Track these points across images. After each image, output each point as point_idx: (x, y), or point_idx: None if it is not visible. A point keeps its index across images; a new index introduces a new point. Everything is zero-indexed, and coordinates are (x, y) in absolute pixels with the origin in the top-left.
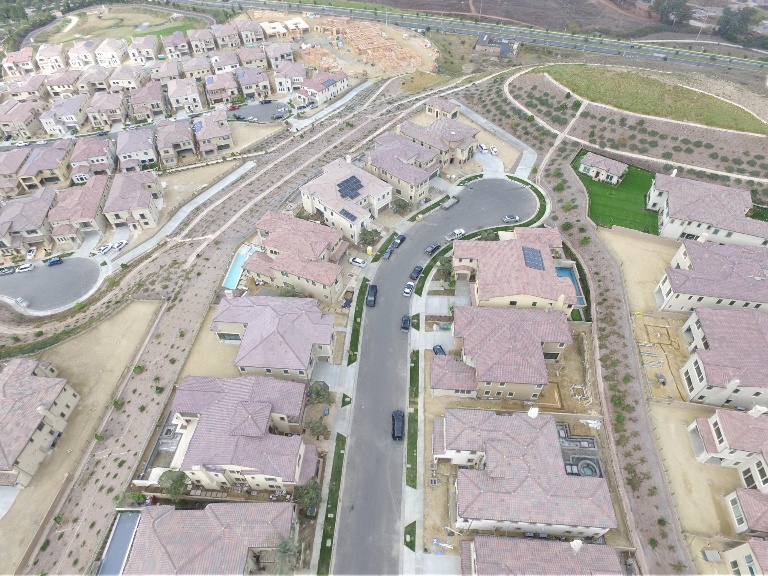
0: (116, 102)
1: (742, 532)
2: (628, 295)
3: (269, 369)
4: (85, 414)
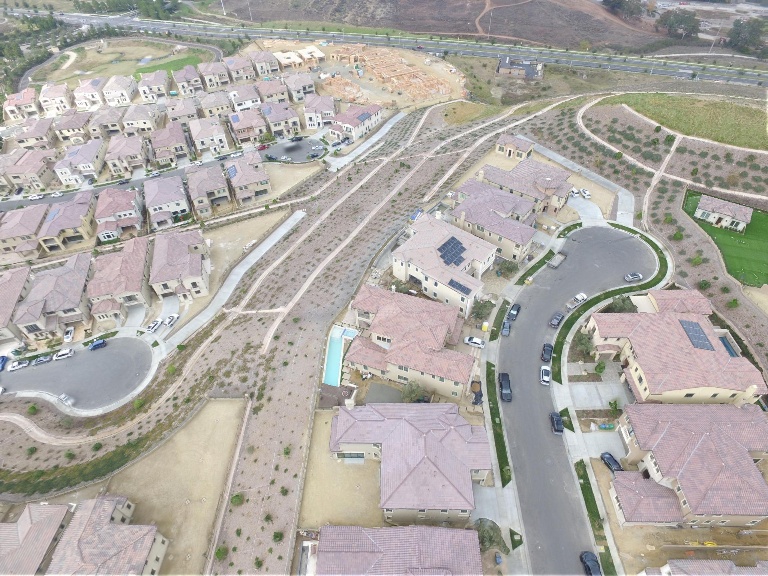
0: (136, 147)
1: None
2: None
3: (424, 509)
4: (178, 566)
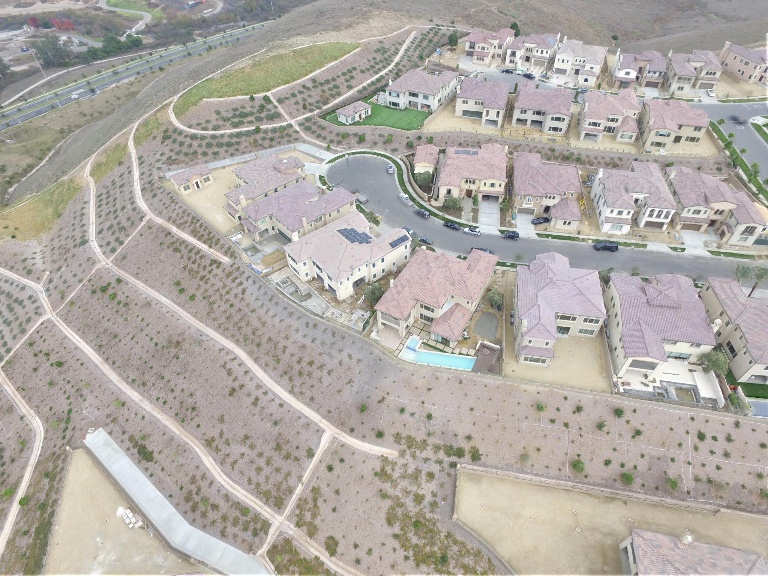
0: None
1: (635, 139)
2: None
3: None
4: None
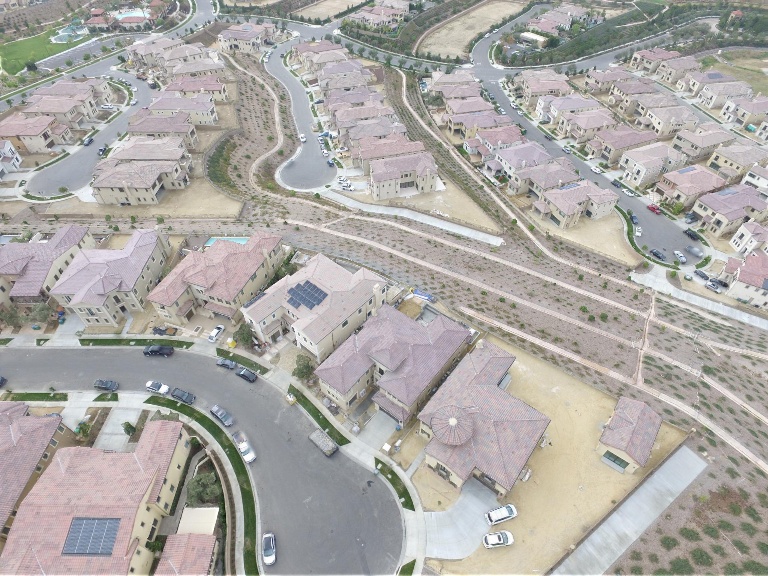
0: (593, 124)
1: None
2: None
3: None
4: (142, 210)
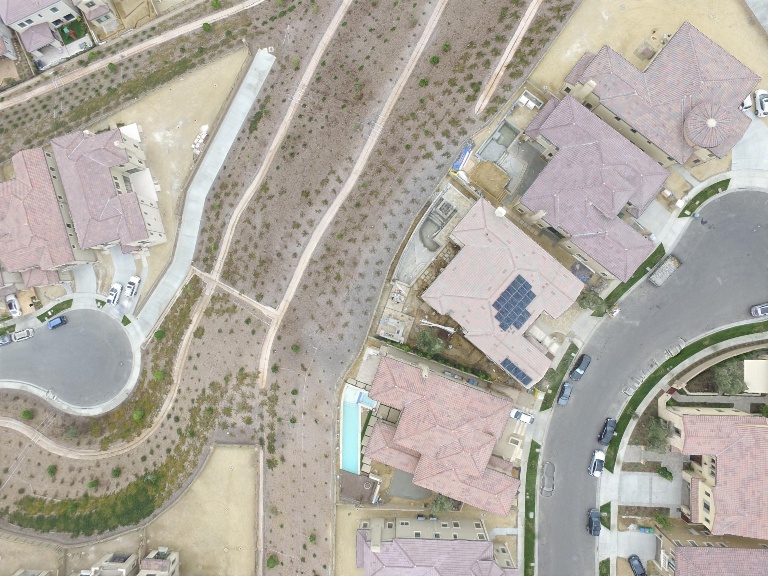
0: None
1: None
2: None
3: None
4: None
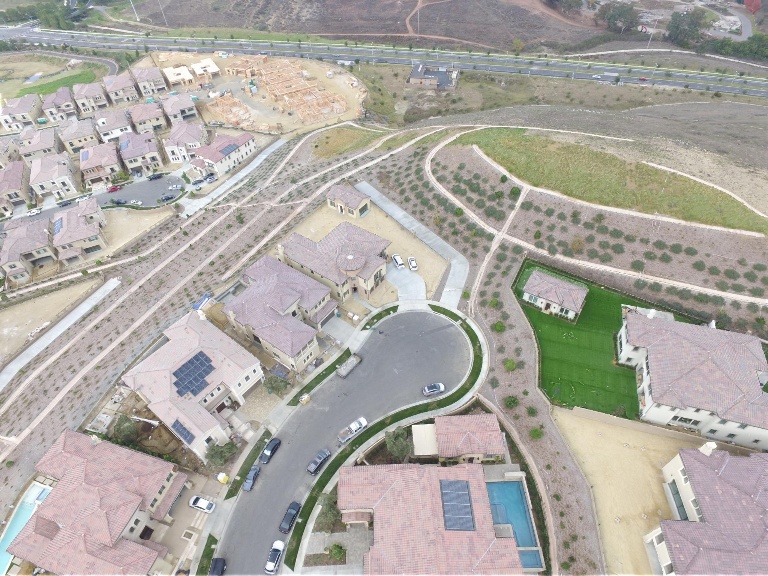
0: None
1: None
2: (606, 553)
3: None
4: None
